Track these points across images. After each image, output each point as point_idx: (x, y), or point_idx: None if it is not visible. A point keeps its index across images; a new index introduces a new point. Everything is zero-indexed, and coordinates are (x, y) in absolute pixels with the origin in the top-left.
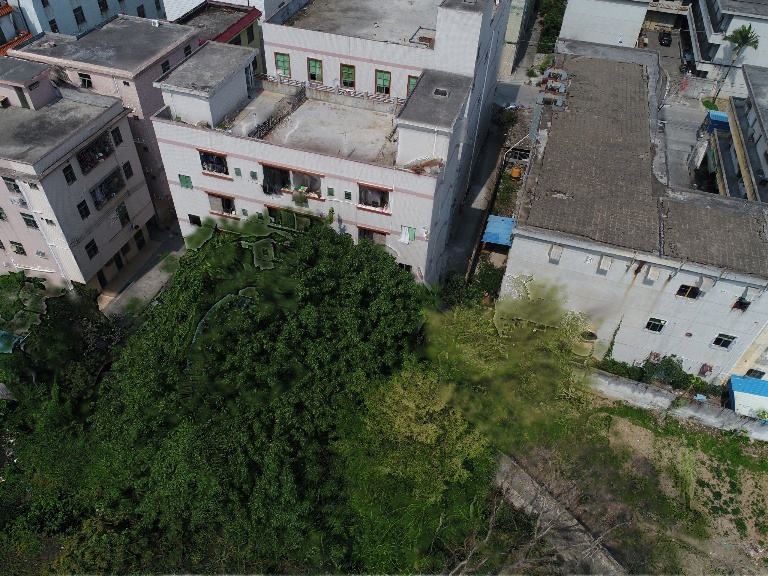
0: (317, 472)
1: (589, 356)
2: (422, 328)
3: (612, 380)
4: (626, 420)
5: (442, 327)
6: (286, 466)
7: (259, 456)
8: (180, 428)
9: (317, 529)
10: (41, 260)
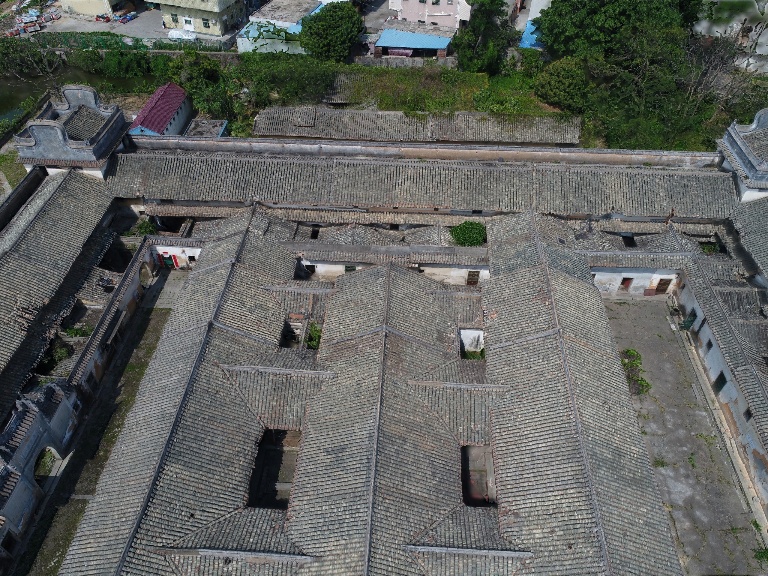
0: (671, 12)
1: (745, 47)
2: (680, 1)
3: (758, 58)
4: (765, 81)
5: (688, 3)
6: (662, 5)
7: (649, 4)
8: (605, 7)
9: (666, 42)
10: (447, 7)
